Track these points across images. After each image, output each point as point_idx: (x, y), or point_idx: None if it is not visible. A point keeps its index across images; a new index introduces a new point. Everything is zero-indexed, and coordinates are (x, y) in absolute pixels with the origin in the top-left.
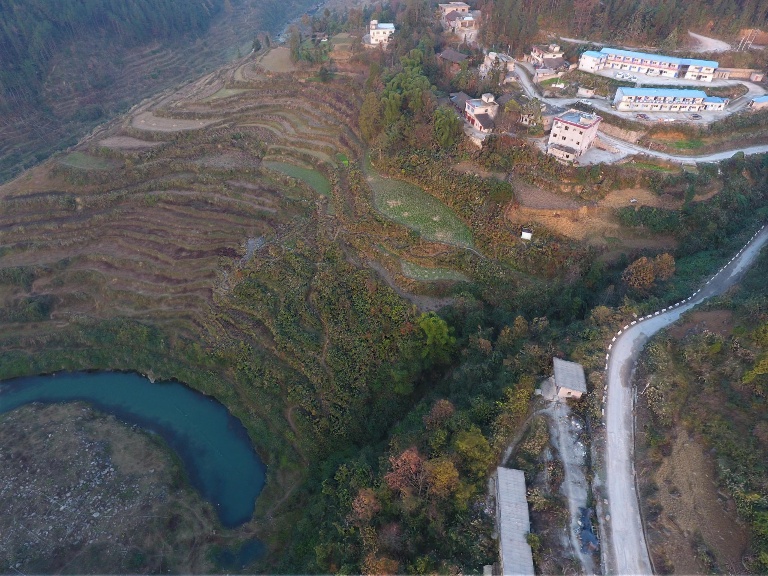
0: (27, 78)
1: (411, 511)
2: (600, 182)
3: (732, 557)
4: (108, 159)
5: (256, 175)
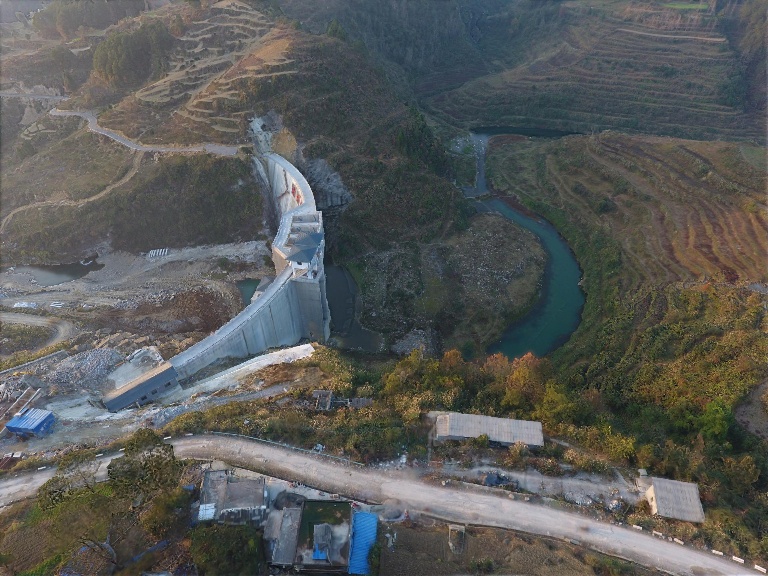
0: None
1: None
2: None
3: None
4: None
5: None
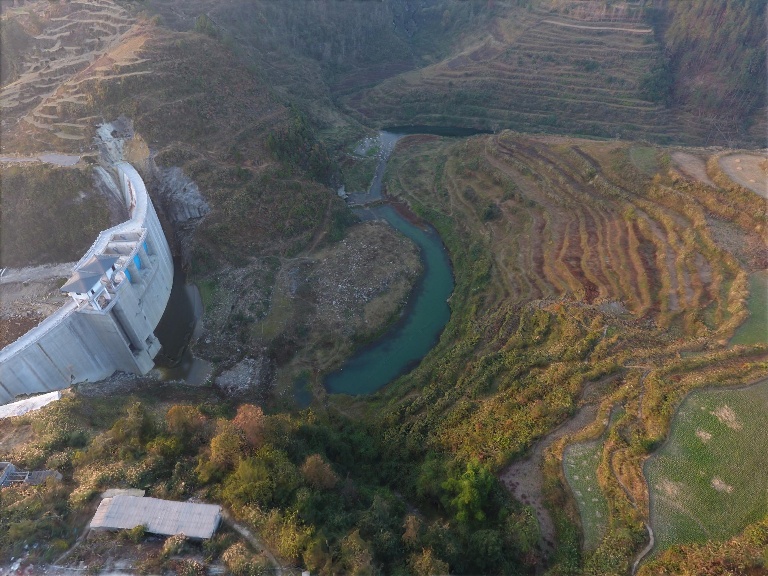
0: (767, 89)
1: None
2: None
3: None
4: (659, 167)
5: (730, 273)
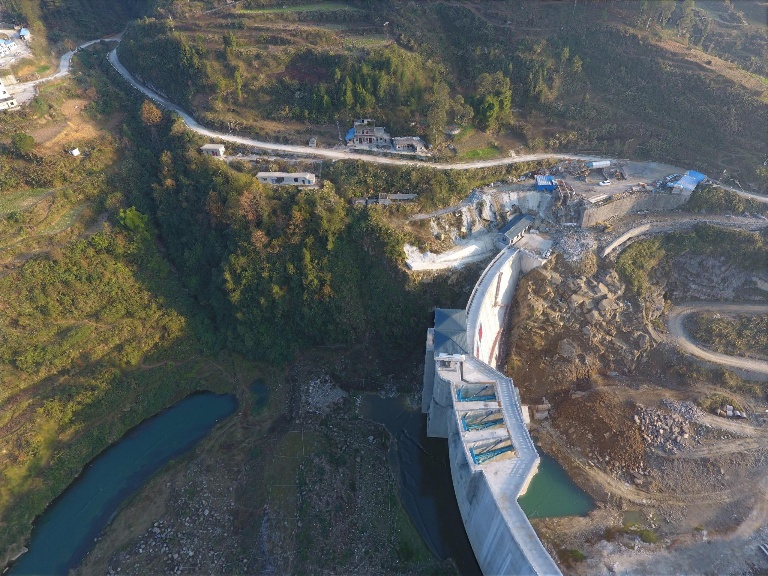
0: None
1: (268, 218)
2: (49, 107)
3: (304, 126)
4: None
5: None
